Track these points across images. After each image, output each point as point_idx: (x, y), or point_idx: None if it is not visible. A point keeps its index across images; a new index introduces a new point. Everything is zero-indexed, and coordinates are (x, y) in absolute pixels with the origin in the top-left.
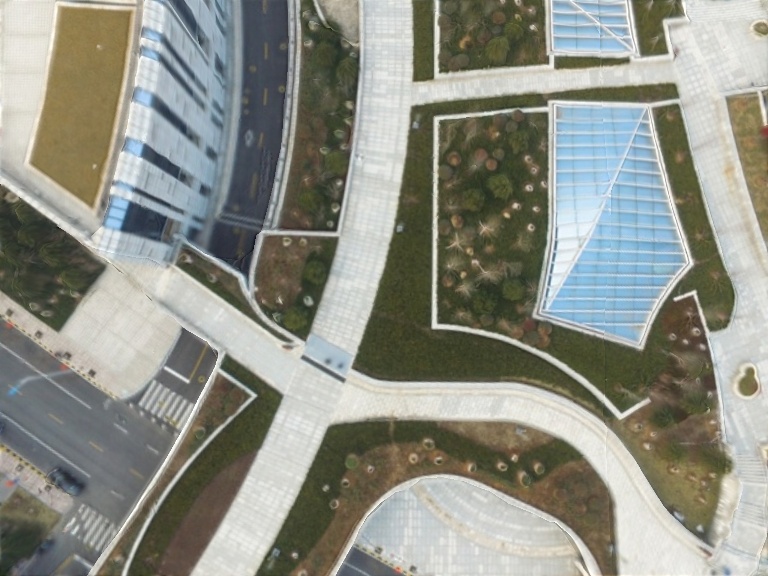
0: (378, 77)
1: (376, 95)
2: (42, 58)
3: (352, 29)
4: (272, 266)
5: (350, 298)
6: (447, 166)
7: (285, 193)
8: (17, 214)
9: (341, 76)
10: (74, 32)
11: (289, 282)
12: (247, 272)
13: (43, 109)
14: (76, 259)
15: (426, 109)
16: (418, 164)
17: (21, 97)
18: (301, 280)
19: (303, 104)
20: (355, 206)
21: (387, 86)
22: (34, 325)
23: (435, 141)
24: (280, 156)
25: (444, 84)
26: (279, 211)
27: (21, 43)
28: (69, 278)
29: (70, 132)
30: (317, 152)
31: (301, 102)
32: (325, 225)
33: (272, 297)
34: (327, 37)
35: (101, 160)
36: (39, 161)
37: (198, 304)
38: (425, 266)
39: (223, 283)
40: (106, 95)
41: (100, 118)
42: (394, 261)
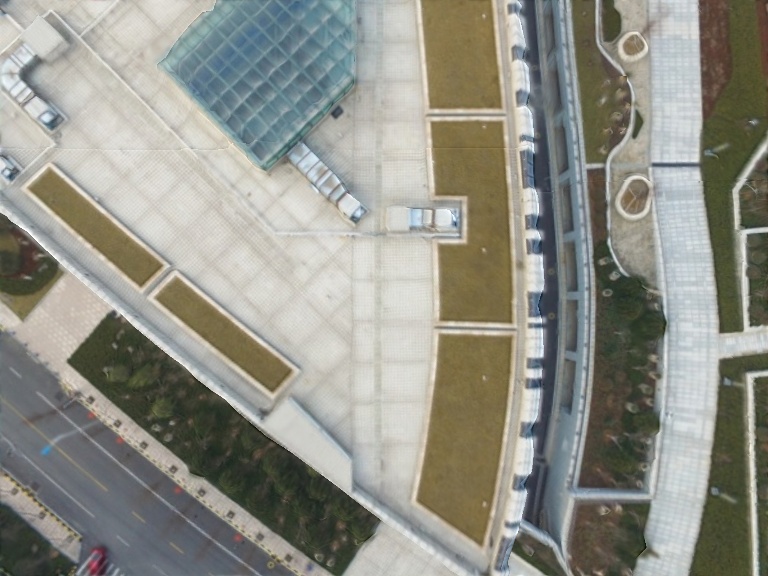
0: (683, 329)
1: (682, 348)
2: (421, 386)
3: (647, 273)
4: (587, 534)
5: (665, 564)
6: (767, 428)
7: (585, 446)
8: (310, 470)
9: (650, 333)
10: (456, 361)
11: (607, 553)
12: (559, 538)
13: (427, 442)
14: (365, 511)
15: (736, 363)
16: (731, 422)
17: (402, 428)
18: (619, 550)
19: (603, 356)
20: (666, 466)
21: (693, 338)
22: (314, 571)
23: (750, 400)
24: (579, 408)
25: (752, 335)
26: (580, 466)
27: (399, 370)
28: (362, 534)
29: (456, 466)
30: (619, 405)
31: (600, 352)
32: (635, 486)
33: (588, 567)
34: (637, 294)
35: (489, 496)
36: (426, 498)
37: (510, 573)
38: (743, 531)
39: (539, 554)
40: (491, 426)
41: (486, 451)
42: (710, 525)
